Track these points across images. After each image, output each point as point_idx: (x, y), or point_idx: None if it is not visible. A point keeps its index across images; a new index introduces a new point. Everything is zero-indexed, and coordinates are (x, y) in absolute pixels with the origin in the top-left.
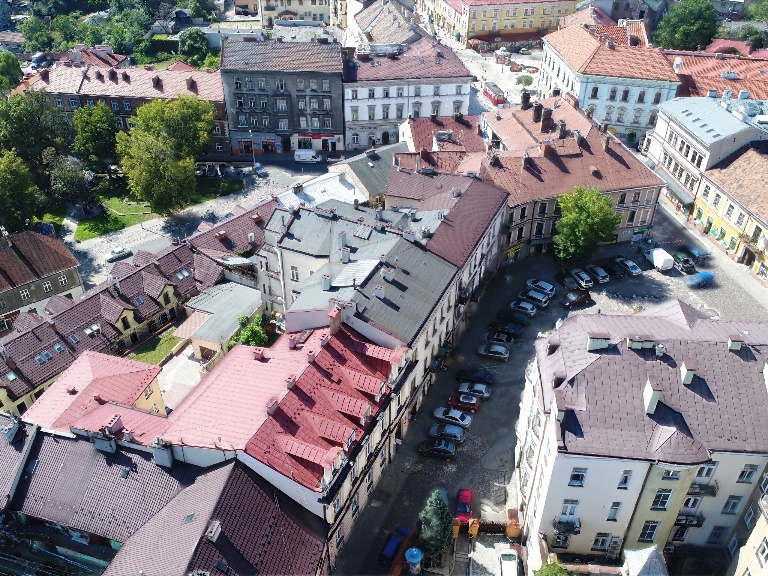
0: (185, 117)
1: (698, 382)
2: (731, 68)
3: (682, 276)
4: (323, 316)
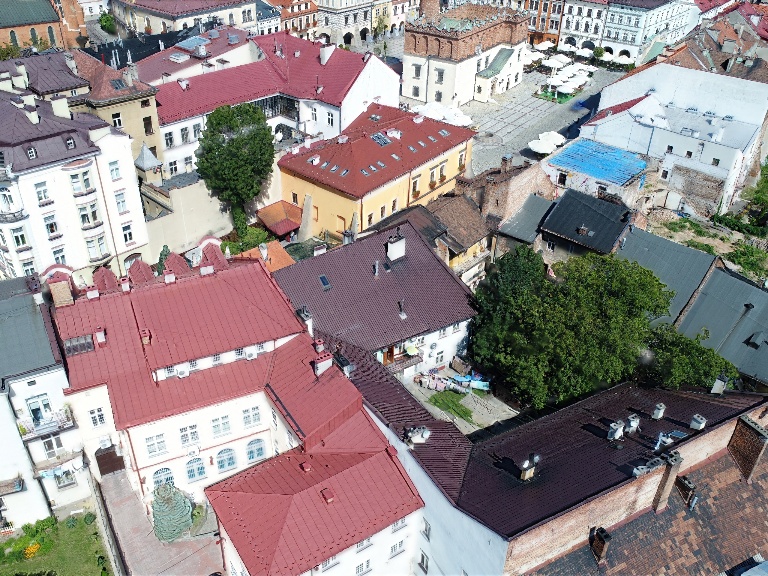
0: None
1: None
2: None
3: None
4: None
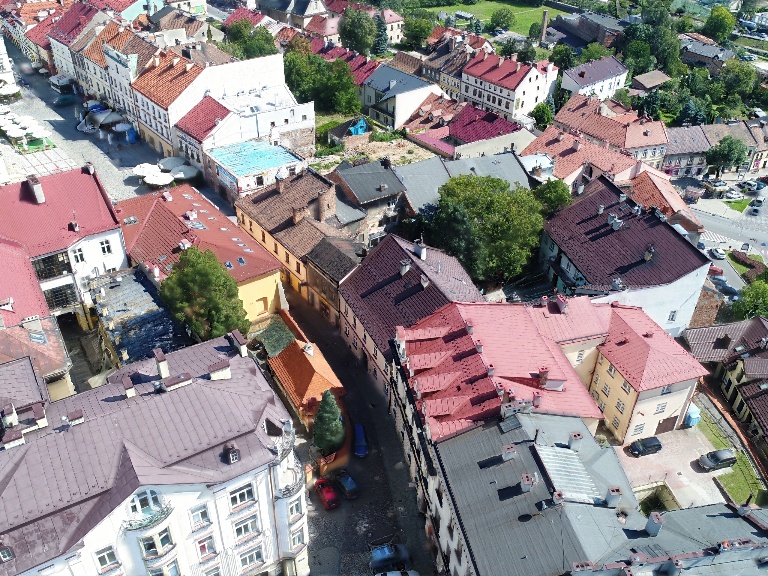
0: None
1: None
2: None
3: None
4: None
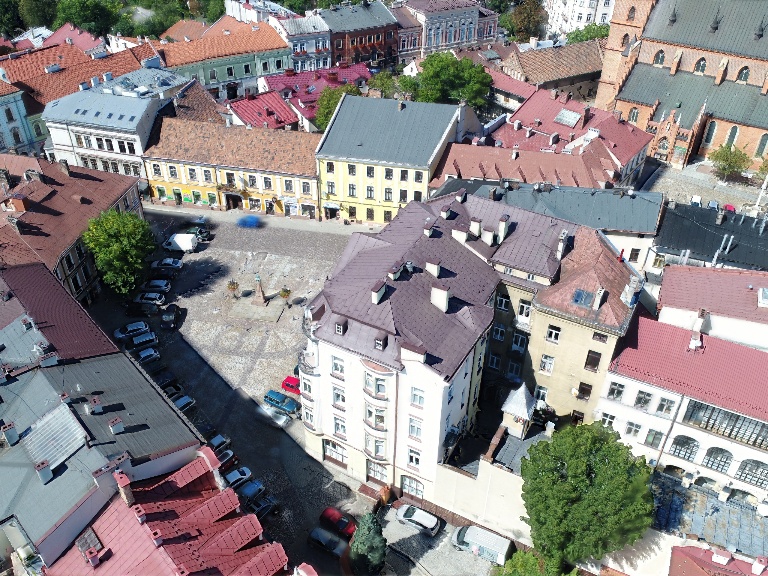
0: None
1: (440, 270)
2: (33, 63)
3: (209, 245)
4: (94, 502)
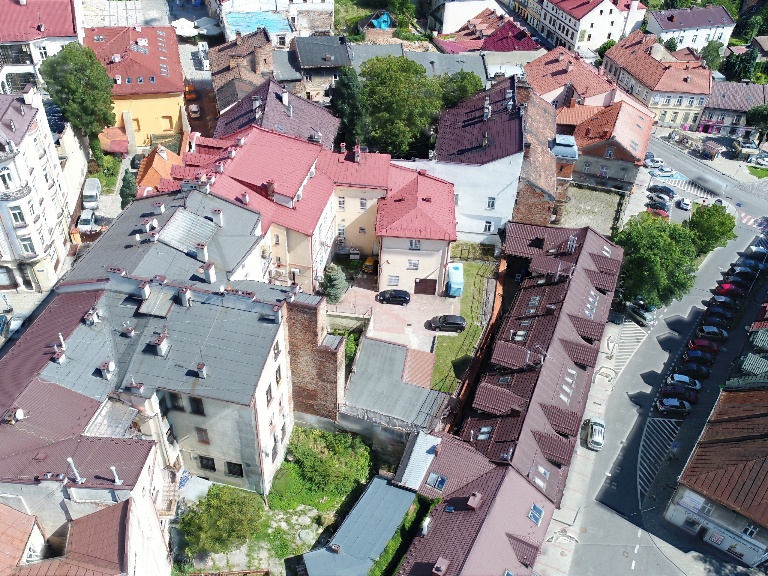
0: None
1: None
2: None
3: None
4: None
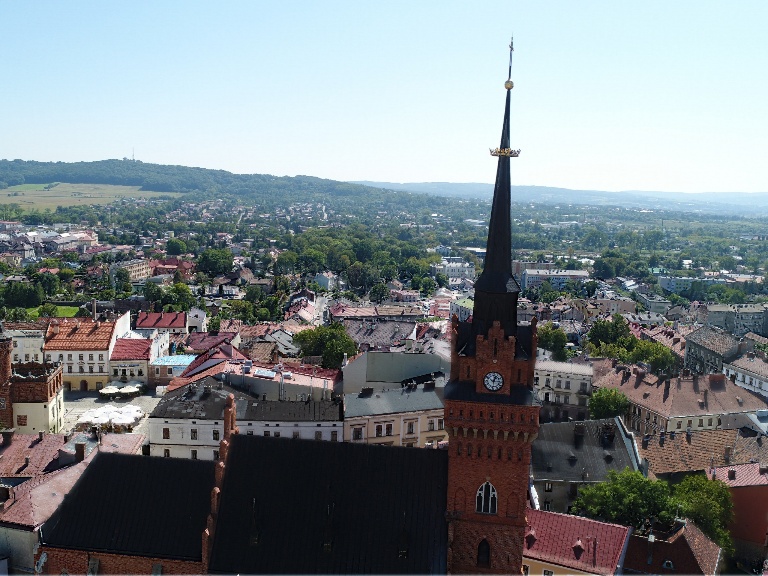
0: (650, 352)
1: None
2: None
3: None
4: None
